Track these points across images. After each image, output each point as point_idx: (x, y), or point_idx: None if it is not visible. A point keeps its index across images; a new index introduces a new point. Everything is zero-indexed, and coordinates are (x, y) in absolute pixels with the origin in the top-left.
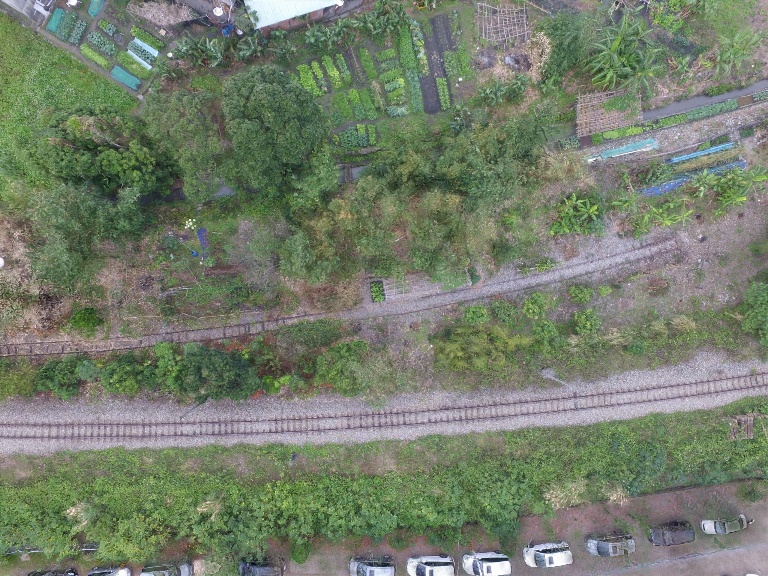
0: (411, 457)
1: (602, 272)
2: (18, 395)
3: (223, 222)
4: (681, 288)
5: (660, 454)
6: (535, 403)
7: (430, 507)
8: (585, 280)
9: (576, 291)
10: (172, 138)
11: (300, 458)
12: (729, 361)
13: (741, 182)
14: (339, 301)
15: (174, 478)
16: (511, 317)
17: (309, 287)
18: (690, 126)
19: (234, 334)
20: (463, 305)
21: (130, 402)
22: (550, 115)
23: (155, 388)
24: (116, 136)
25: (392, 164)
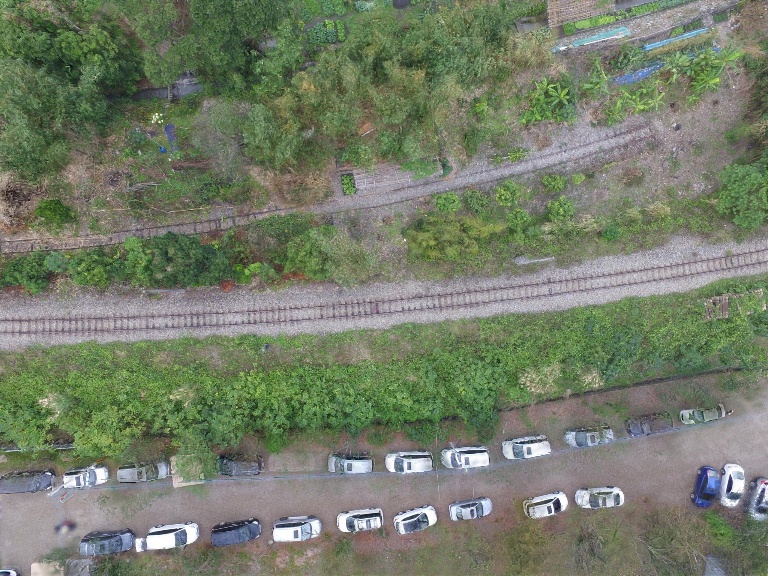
0: (385, 346)
1: (576, 161)
2: None
3: (191, 118)
4: (656, 178)
5: (635, 335)
6: (509, 289)
7: (404, 392)
8: (559, 170)
9: (549, 179)
10: (128, 4)
11: (273, 348)
12: (704, 243)
13: (714, 61)
14: (309, 192)
15: (147, 371)
16: (485, 209)
17: (279, 180)
18: (663, 14)
19: (205, 230)
20: None
21: (101, 297)
22: (522, 8)
23: (126, 282)
24: (76, 19)
25: (359, 48)
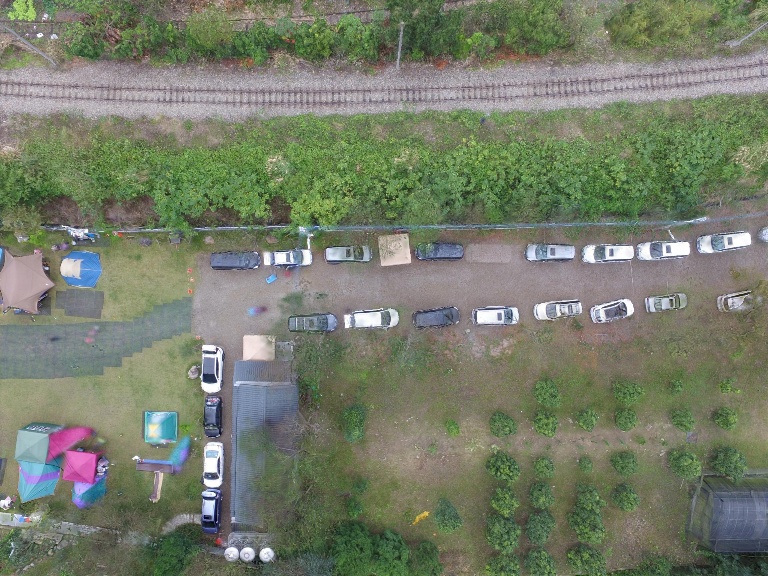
0: (597, 124)
1: None
2: (208, 65)
3: None
4: None
5: None
6: (721, 70)
7: None
8: None
9: None
10: None
11: (489, 123)
12: None
13: None
14: None
15: (364, 143)
16: None
17: None
18: None
19: None
20: None
21: (317, 73)
22: None
23: (342, 58)
24: None
25: None
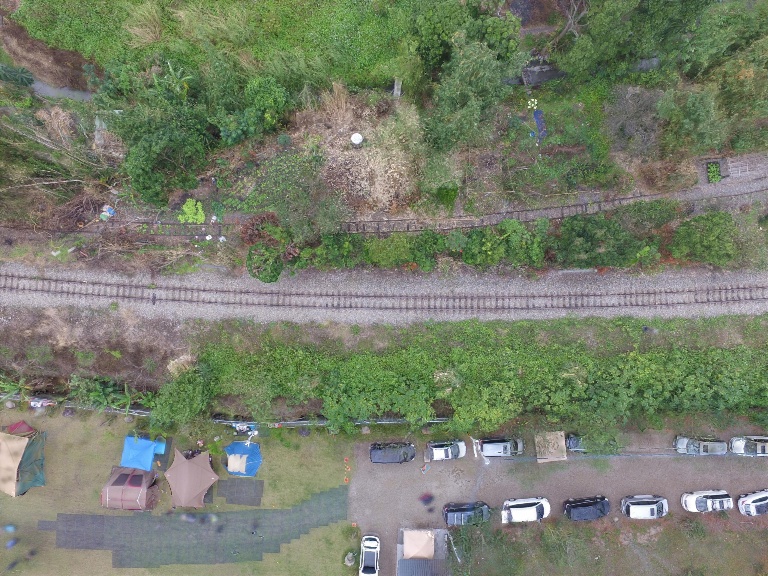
0: (758, 331)
1: None
2: (373, 269)
3: (558, 104)
4: None
5: None
6: None
7: None
8: None
9: None
10: None
11: (651, 331)
12: None
13: None
14: (683, 179)
15: (528, 349)
16: None
17: (647, 167)
18: None
19: (571, 214)
20: None
21: (480, 277)
22: None
23: (506, 263)
24: (494, 5)
25: (751, 38)
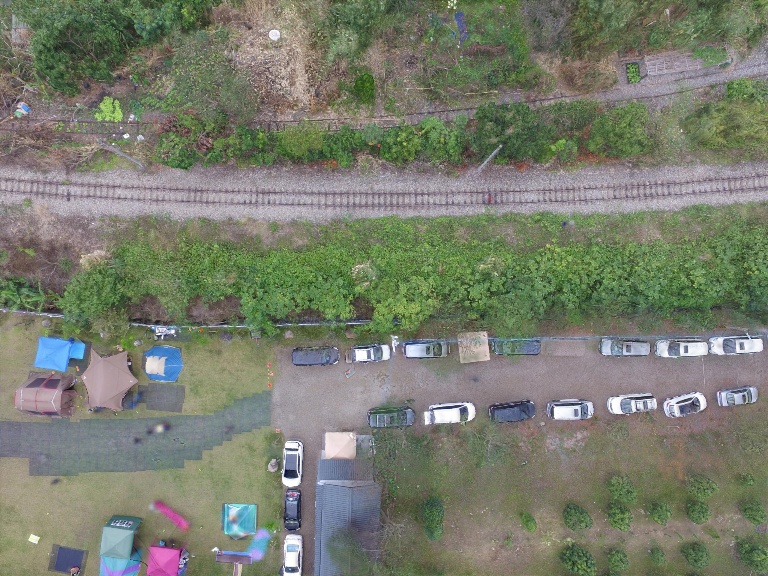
0: (676, 227)
1: None
2: (292, 167)
3: (479, 6)
4: None
5: None
6: None
7: (703, 269)
8: None
9: None
10: None
11: (570, 226)
12: None
13: None
14: (601, 77)
15: (447, 245)
16: None
17: (567, 67)
18: None
19: None
20: (714, 89)
21: (400, 174)
22: None
23: (425, 160)
24: None
25: None
